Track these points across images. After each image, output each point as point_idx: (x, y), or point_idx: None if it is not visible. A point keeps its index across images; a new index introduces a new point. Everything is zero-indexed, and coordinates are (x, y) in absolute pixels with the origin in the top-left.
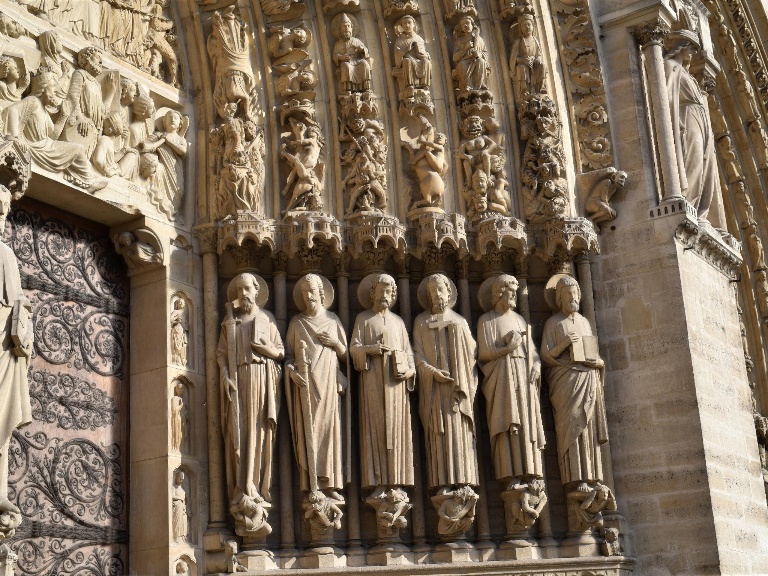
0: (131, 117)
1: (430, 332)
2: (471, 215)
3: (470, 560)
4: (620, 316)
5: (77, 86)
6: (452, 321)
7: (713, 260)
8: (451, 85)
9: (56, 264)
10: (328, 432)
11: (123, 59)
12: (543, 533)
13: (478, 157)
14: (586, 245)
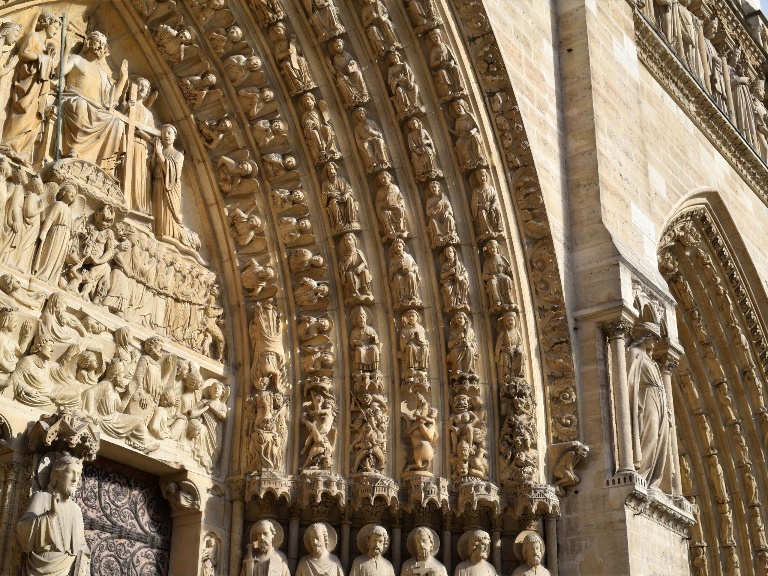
0: (183, 389)
1: None
2: (455, 478)
3: None
4: (578, 569)
5: (142, 369)
6: (432, 568)
7: (665, 521)
8: (445, 367)
9: (114, 508)
10: None
11: (180, 343)
12: None
13: (463, 429)
14: (548, 509)
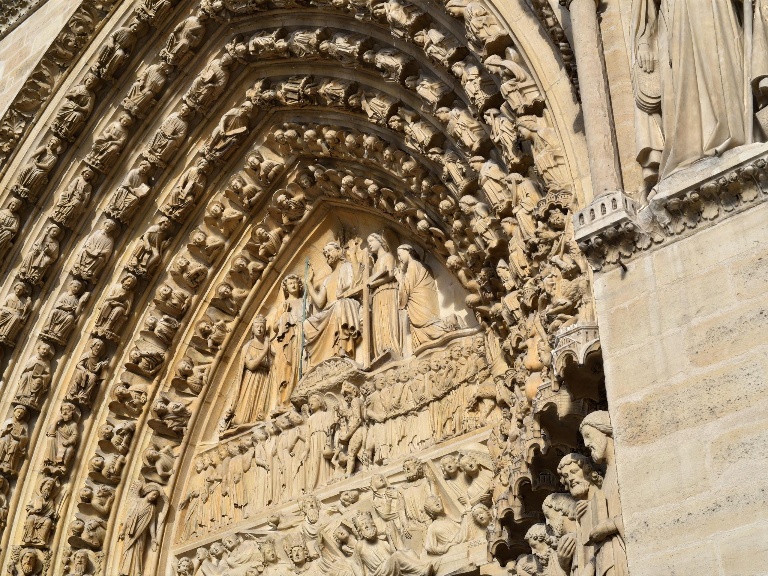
0: (471, 479)
1: None
2: None
3: None
4: None
5: None
6: None
7: (763, 190)
8: None
9: None
10: None
11: None
12: None
13: None
14: None
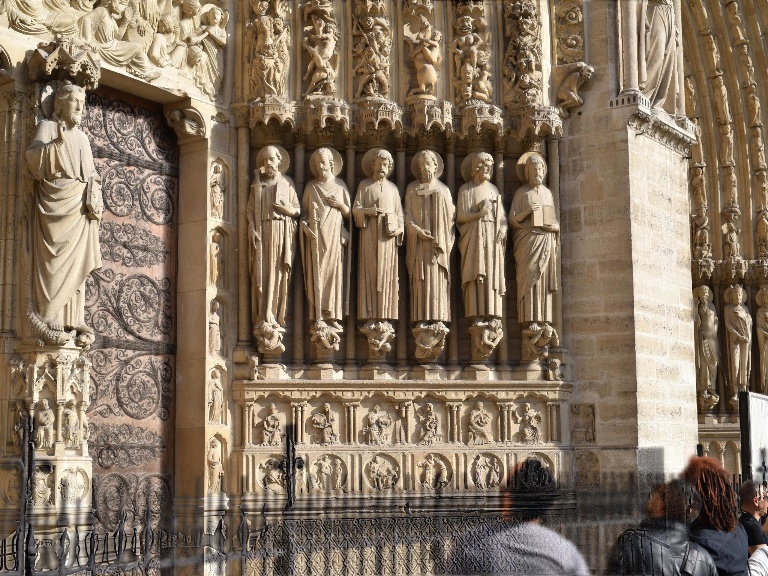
0: (181, 15)
1: (418, 198)
2: (458, 101)
3: (440, 379)
4: (579, 188)
5: None
6: (436, 190)
7: (667, 141)
8: None
9: (121, 137)
10: (332, 276)
11: None
12: (501, 360)
13: (467, 52)
14: (551, 130)
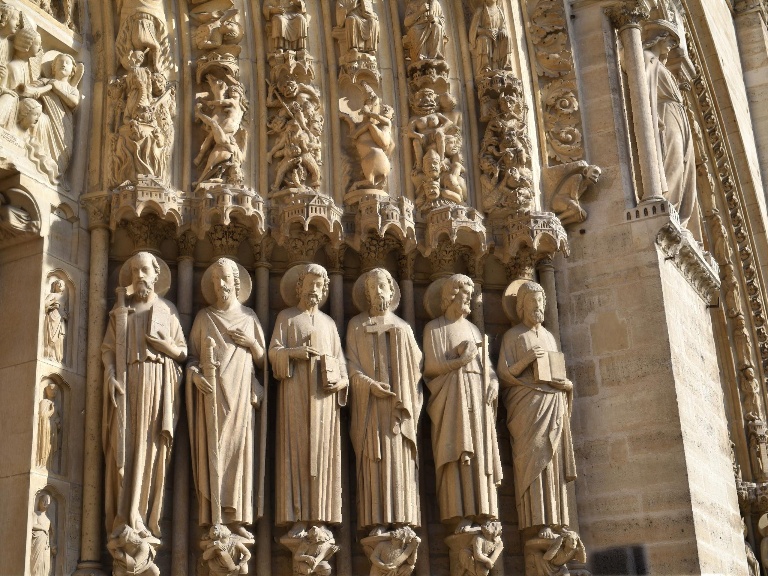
0: (11, 53)
1: (367, 337)
2: (420, 203)
3: None
4: (589, 333)
5: None
6: (394, 325)
7: (691, 278)
8: (401, 53)
9: None
10: (237, 452)
11: None
12: None
13: (431, 136)
14: (555, 244)
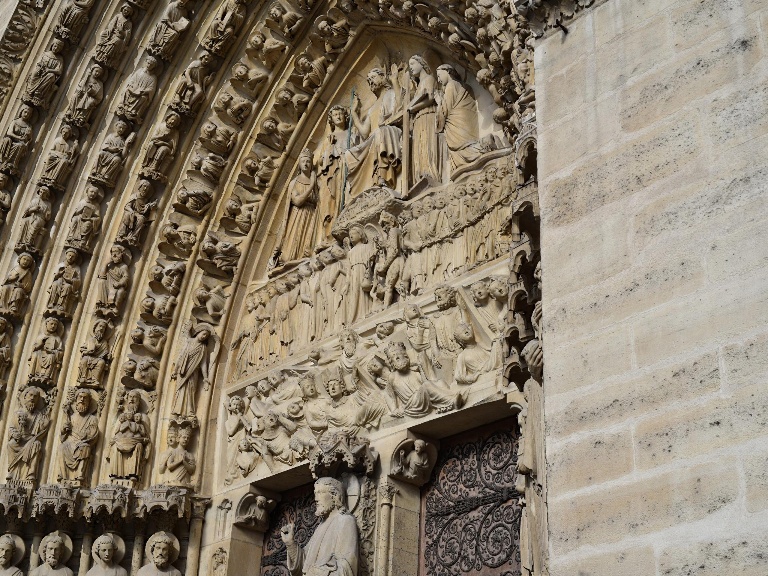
0: (502, 305)
1: None
2: None
3: None
4: None
5: None
6: None
7: None
8: None
9: None
10: None
11: None
12: None
13: None
14: None
